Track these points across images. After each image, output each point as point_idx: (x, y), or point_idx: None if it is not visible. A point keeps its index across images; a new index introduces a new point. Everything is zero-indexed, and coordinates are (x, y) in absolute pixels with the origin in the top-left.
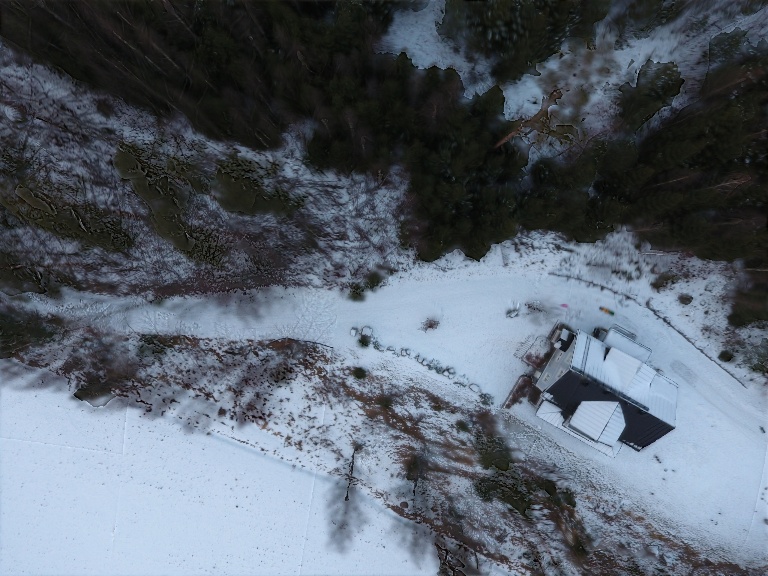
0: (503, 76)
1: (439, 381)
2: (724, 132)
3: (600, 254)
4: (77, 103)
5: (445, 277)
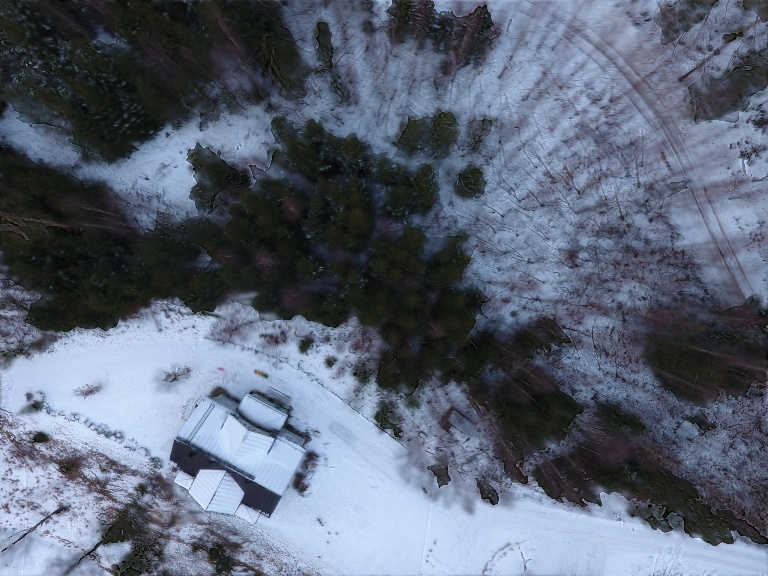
0: None
1: (110, 445)
2: (255, 213)
3: None
4: None
5: (106, 343)
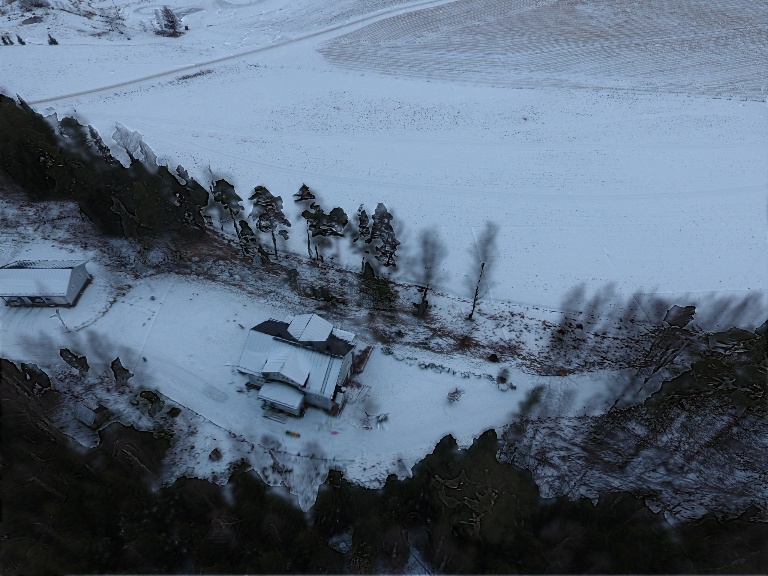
0: None
1: (430, 359)
2: None
3: (308, 485)
4: None
5: None
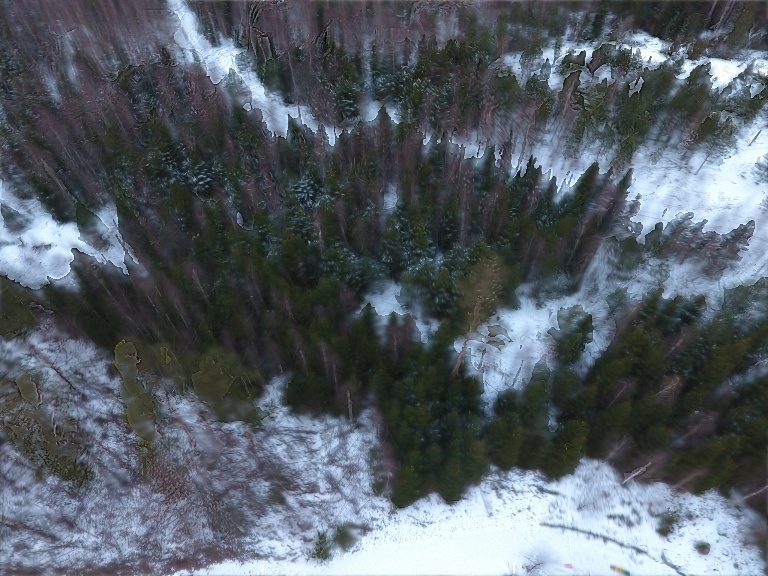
0: (454, 333)
1: None
2: (641, 350)
3: (587, 495)
4: (90, 368)
5: (425, 535)
